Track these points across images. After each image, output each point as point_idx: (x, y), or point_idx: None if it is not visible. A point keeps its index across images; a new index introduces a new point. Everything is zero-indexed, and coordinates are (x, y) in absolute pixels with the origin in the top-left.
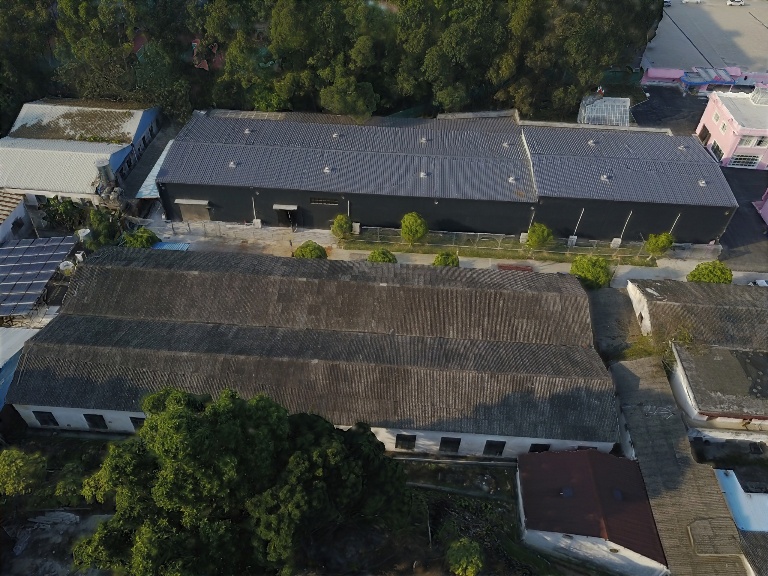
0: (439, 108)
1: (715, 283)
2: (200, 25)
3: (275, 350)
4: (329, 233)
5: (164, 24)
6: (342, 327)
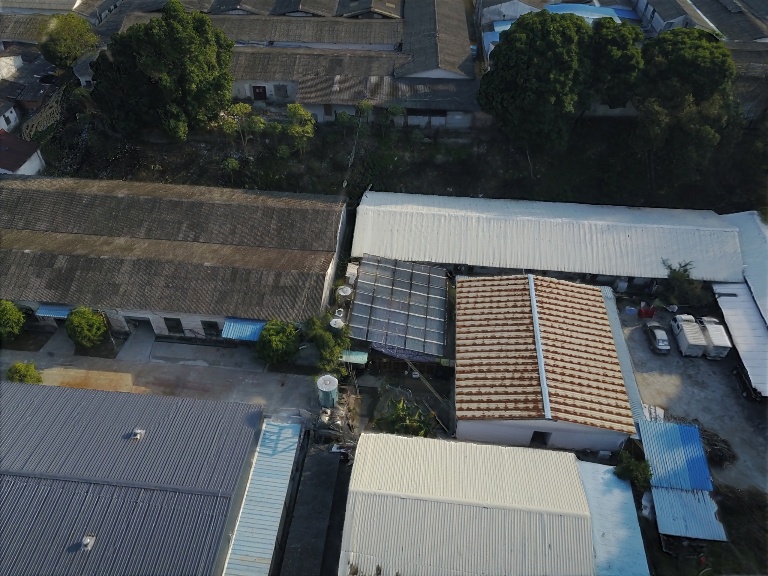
0: None
1: None
2: None
3: (149, 208)
4: None
5: None
6: (88, 236)
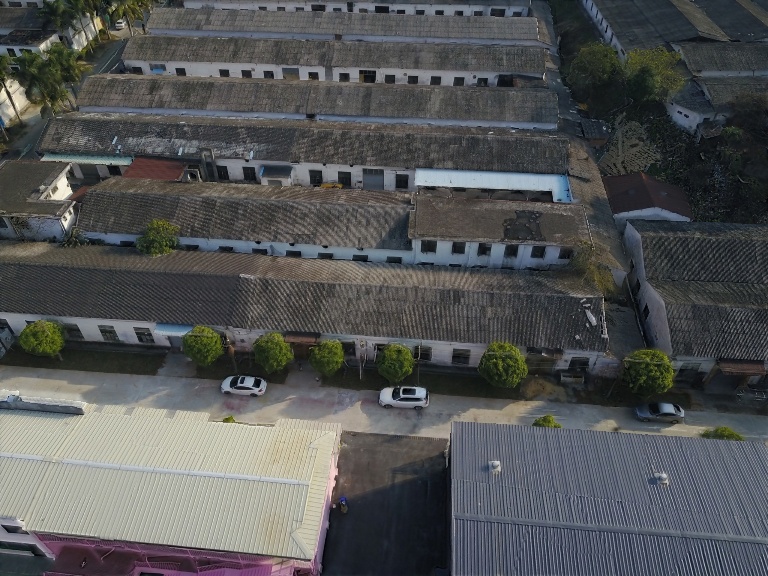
0: None
1: None
2: None
3: None
4: None
5: None
6: None
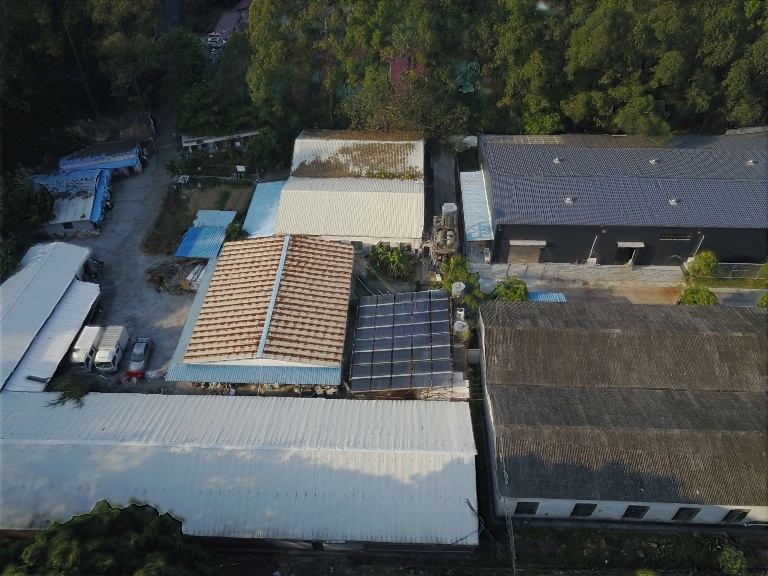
0: (728, 123)
1: None
2: (489, 47)
3: (766, 422)
4: (669, 270)
5: (450, 48)
6: None
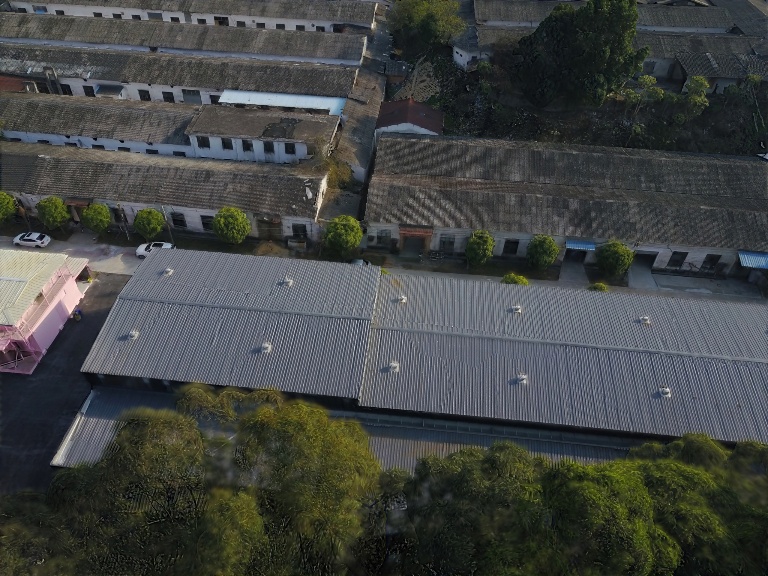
0: None
1: None
2: None
3: (605, 163)
4: None
5: None
6: None
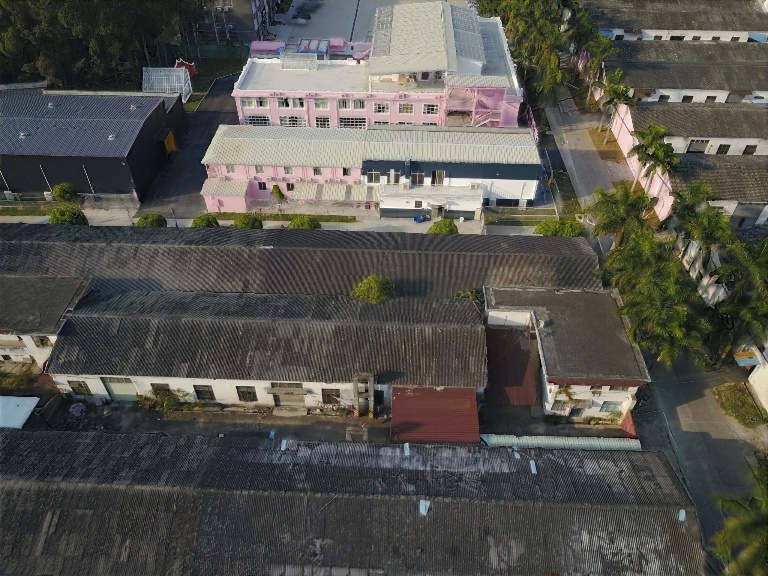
0: None
1: (53, 224)
2: None
3: None
4: None
5: None
6: None
